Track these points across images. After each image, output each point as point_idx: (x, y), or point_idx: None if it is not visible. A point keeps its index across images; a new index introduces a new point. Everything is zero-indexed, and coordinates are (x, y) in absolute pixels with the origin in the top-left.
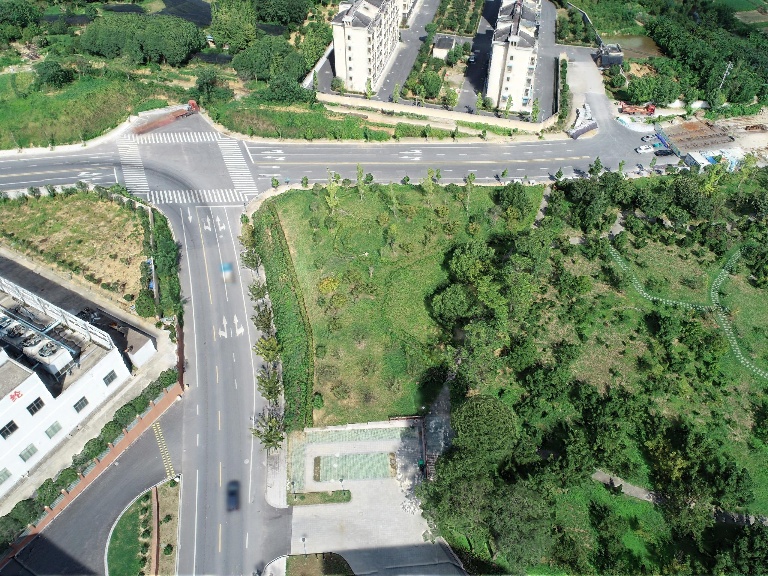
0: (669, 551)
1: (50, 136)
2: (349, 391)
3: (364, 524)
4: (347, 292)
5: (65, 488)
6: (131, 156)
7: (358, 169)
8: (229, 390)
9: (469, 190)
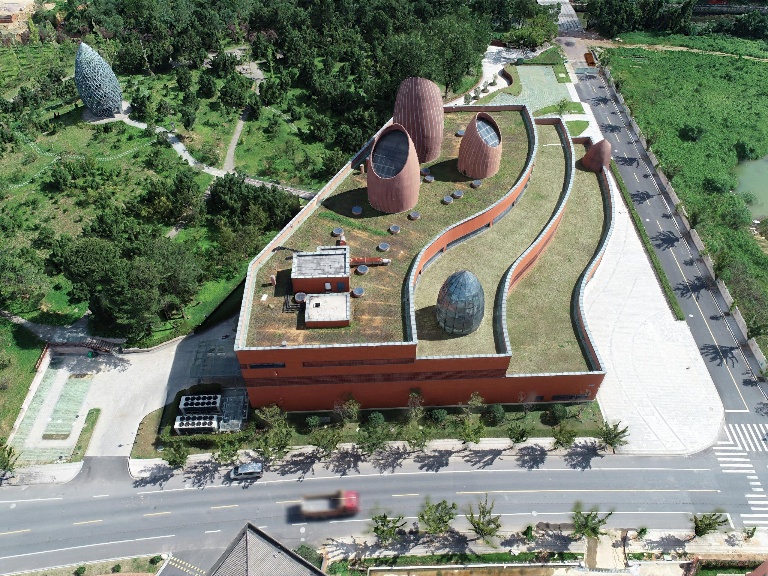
0: (212, 231)
1: None
2: None
3: (125, 399)
4: None
5: None
6: None
7: None
8: None
9: None
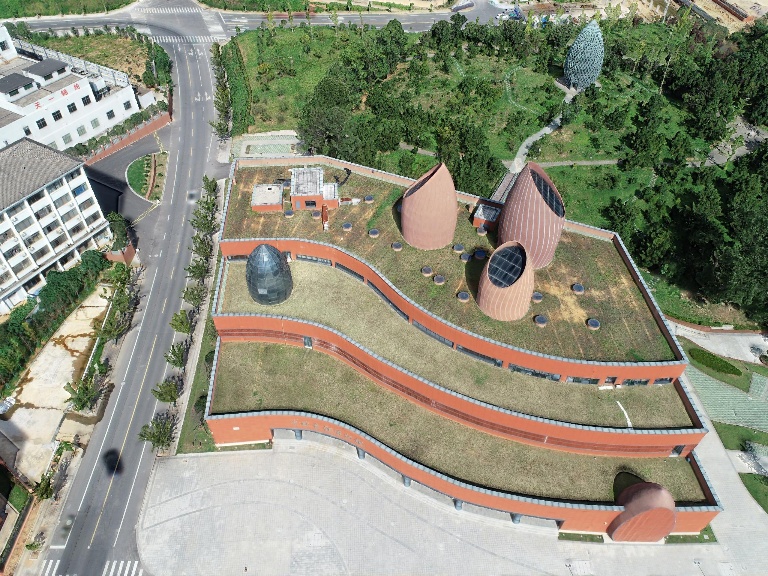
0: None
1: (83, 7)
2: (271, 118)
3: None
4: (276, 73)
5: (103, 145)
6: (140, 19)
7: (288, 7)
8: (199, 121)
9: (362, 23)
